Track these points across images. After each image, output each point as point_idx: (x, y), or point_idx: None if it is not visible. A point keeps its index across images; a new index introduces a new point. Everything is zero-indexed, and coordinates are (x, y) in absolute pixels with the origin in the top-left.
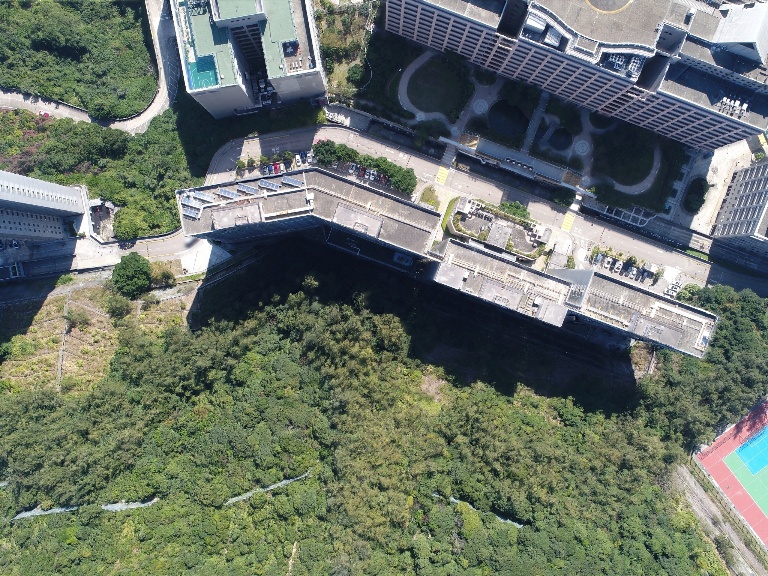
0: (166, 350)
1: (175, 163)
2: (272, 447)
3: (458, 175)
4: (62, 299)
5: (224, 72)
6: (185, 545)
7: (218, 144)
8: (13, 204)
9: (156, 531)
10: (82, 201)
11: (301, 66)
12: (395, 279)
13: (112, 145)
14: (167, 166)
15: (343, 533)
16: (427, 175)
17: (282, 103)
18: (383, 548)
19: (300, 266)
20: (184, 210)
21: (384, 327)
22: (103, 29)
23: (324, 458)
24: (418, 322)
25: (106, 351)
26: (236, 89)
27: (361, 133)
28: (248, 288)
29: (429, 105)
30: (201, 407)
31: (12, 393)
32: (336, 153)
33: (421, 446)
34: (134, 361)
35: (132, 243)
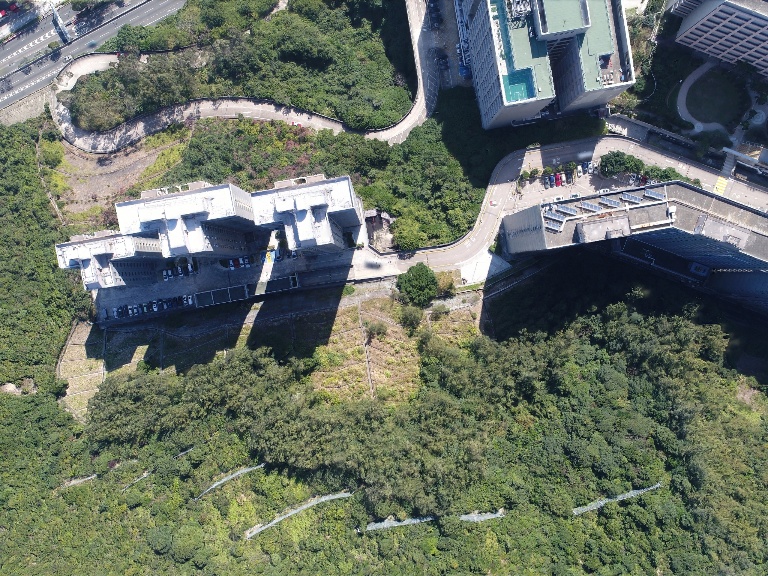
0: (477, 360)
1: (452, 174)
2: (616, 457)
3: (737, 185)
4: (354, 310)
5: (541, 85)
6: (546, 555)
7: (496, 155)
8: (350, 217)
9: (520, 542)
10: (360, 212)
11: (612, 78)
12: (677, 288)
13: (383, 156)
14: (446, 177)
15: (715, 543)
16: (706, 185)
17: (559, 114)
18: (750, 558)
19: (602, 276)
20: (546, 223)
21: (715, 338)
22: (339, 40)
23: (672, 468)
24: (726, 332)
25: (409, 361)
26: (546, 101)
27: (642, 144)
28: (554, 299)
29: (707, 116)
30: (525, 417)
31: (330, 404)
32: (625, 164)
33: (761, 456)
34: (452, 372)
35: (412, 253)
